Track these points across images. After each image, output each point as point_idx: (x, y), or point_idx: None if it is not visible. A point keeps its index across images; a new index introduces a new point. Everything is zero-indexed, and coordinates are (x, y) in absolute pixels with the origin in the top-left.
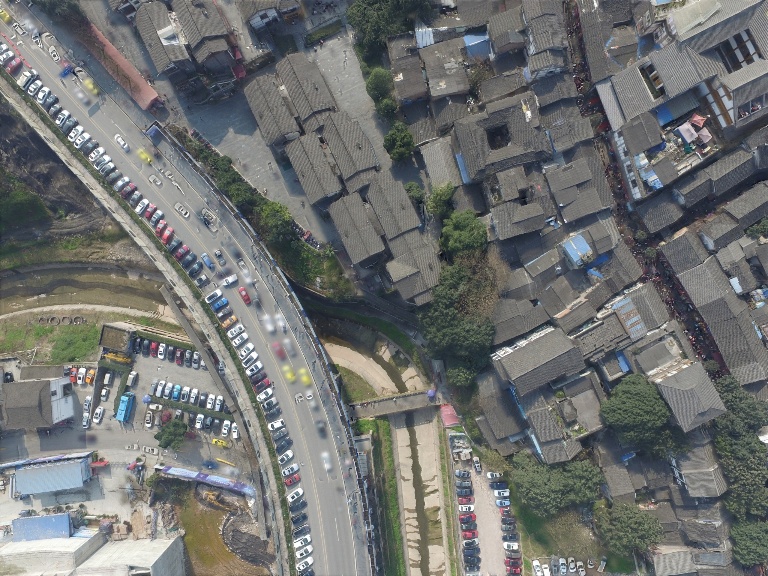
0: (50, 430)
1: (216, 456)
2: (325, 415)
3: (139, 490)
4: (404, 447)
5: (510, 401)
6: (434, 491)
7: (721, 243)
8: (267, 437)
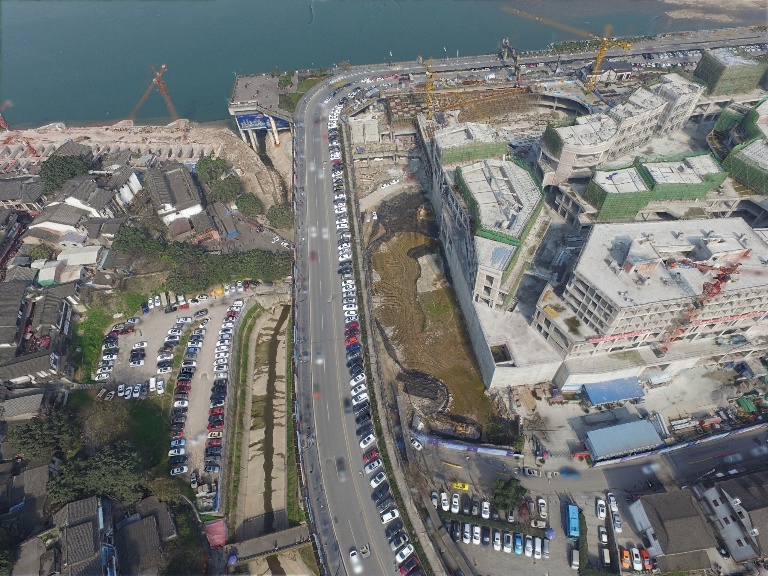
0: (649, 487)
1: (463, 471)
2: (336, 532)
3: (535, 430)
4: (278, 489)
5: (124, 565)
6: (254, 445)
7: None
8: (400, 501)
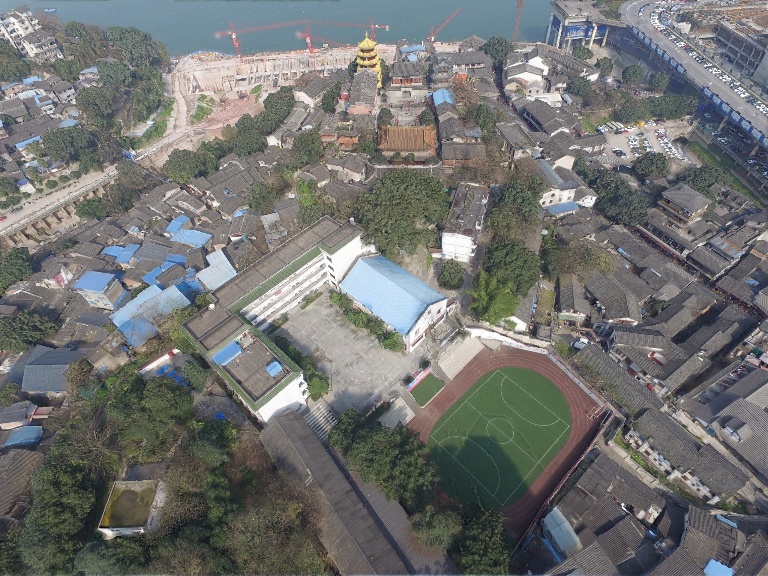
0: None
1: None
2: None
3: None
4: None
5: None
6: None
7: (684, 295)
8: None
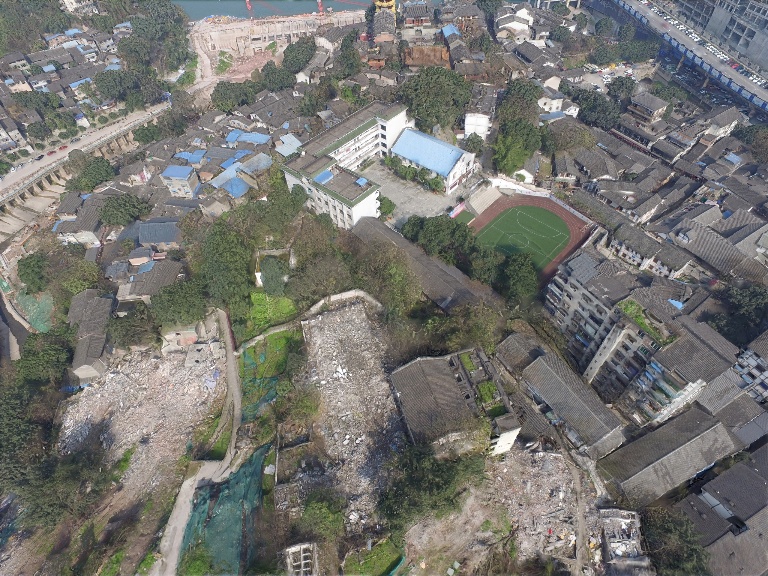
0: None
1: None
2: None
3: None
4: None
5: None
6: None
7: None
8: None
